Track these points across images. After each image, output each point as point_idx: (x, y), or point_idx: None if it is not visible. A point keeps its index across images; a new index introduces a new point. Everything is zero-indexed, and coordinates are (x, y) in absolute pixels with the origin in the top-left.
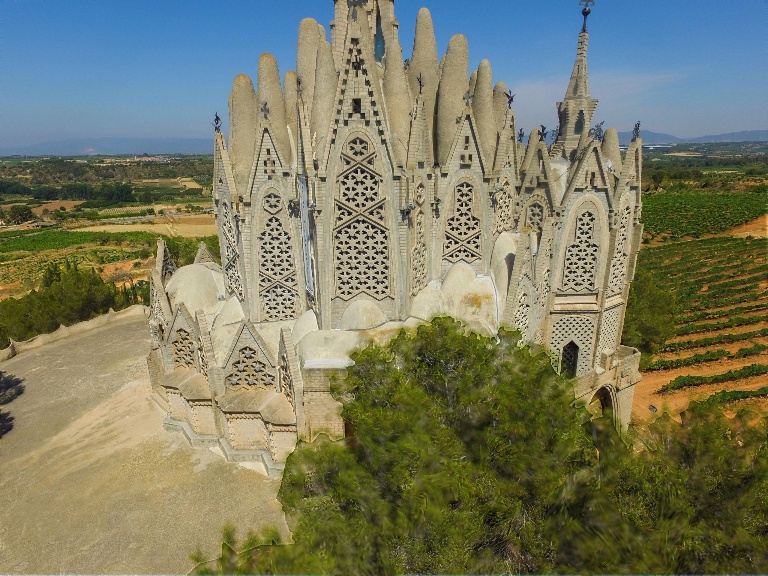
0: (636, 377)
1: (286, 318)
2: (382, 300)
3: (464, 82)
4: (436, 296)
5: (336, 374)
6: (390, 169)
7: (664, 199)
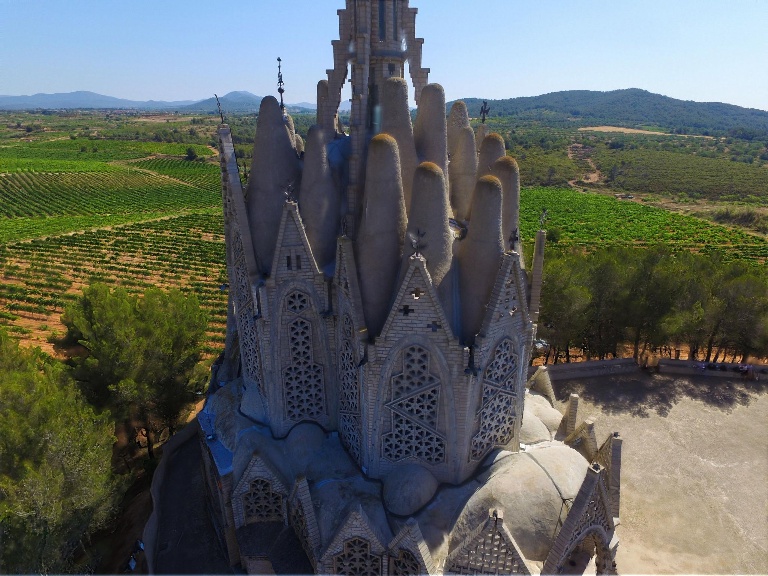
0: None
1: None
2: None
3: None
4: None
5: None
6: None
7: None
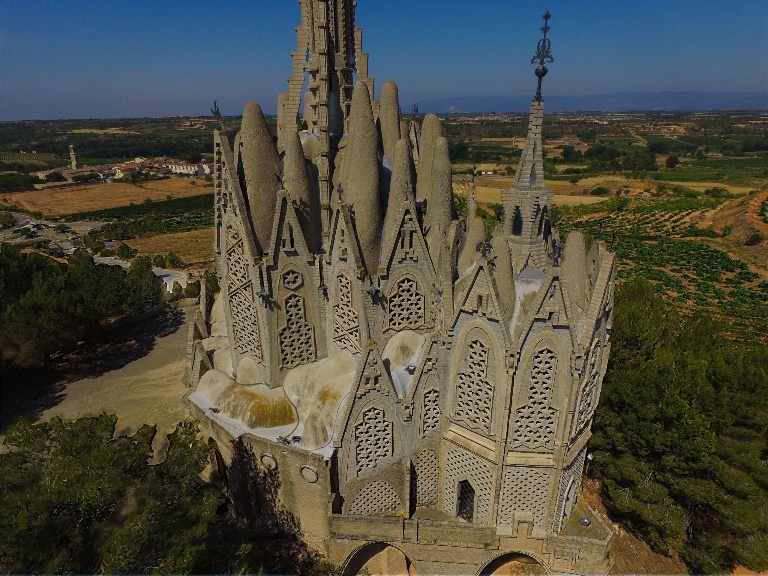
0: (592, 569)
1: None
2: (259, 364)
3: (363, 168)
4: (303, 376)
5: (200, 411)
6: None
7: None
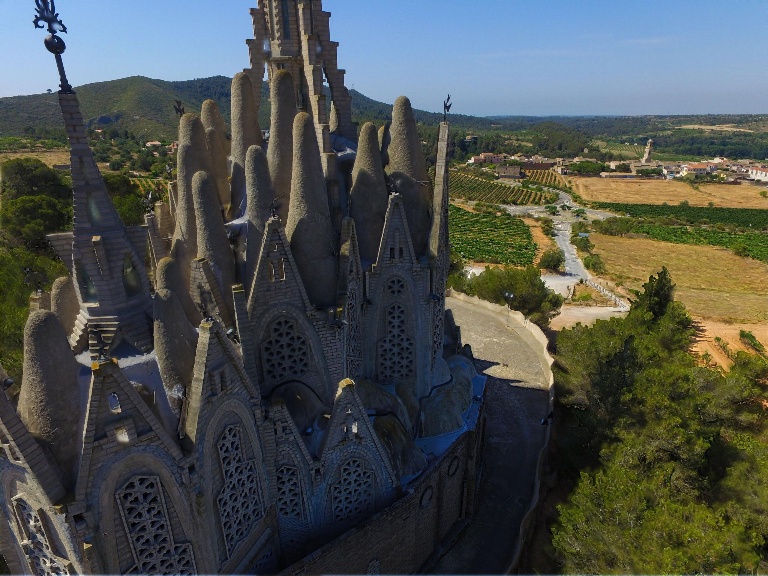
0: None
1: None
2: None
3: None
4: None
5: None
6: None
7: None
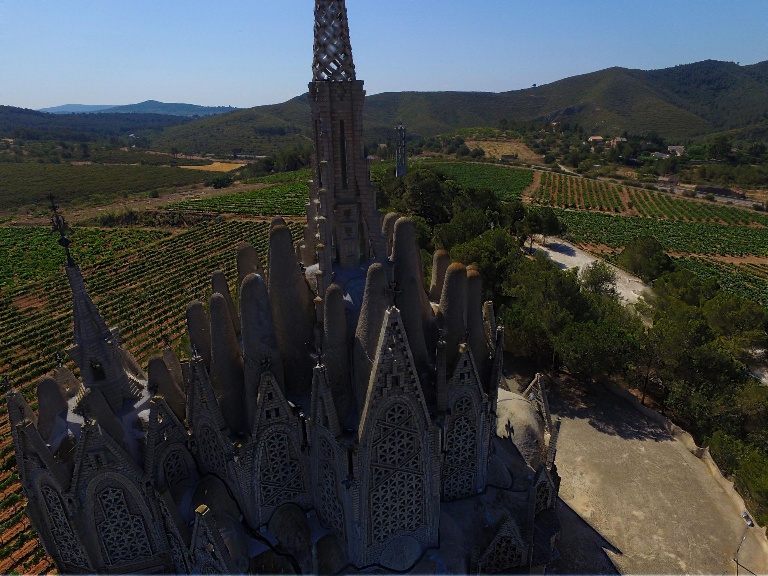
0: None
1: None
2: None
3: None
4: None
5: None
6: None
7: None
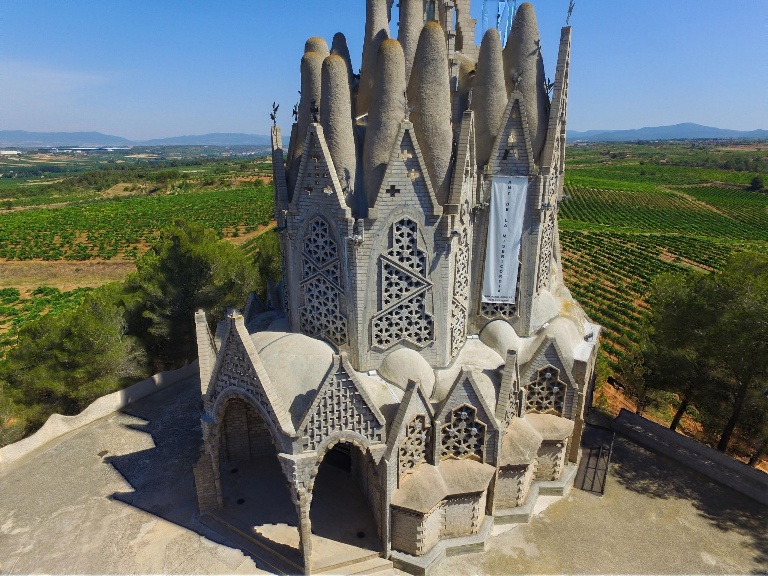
0: None
1: (459, 346)
2: None
3: None
4: None
5: None
6: (559, 165)
7: (198, 197)
